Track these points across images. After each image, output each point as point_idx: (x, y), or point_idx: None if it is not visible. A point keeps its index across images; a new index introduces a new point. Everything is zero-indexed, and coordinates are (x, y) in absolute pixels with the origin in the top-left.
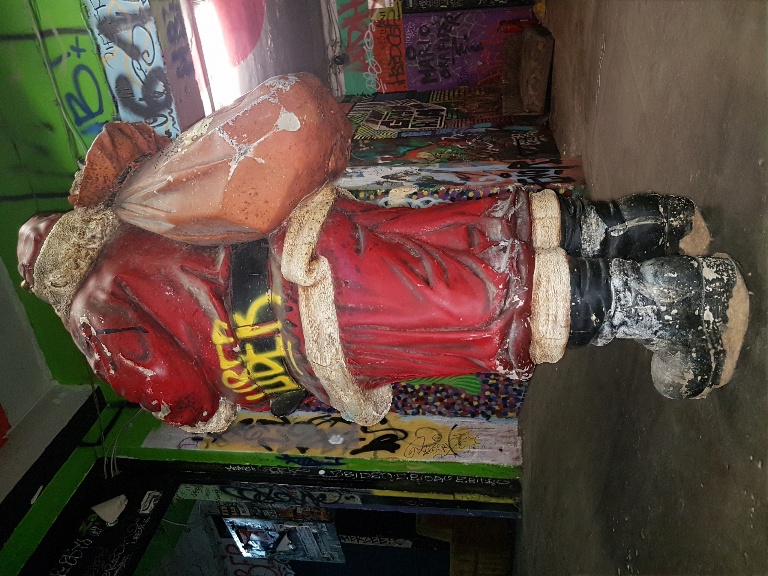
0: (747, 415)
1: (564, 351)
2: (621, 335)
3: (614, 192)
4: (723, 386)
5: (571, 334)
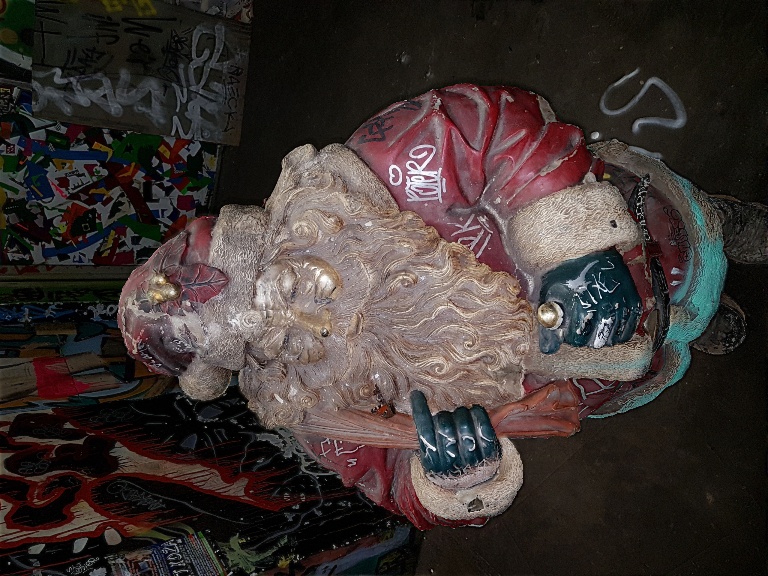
0: None
1: None
2: None
3: (645, 569)
4: None
5: None
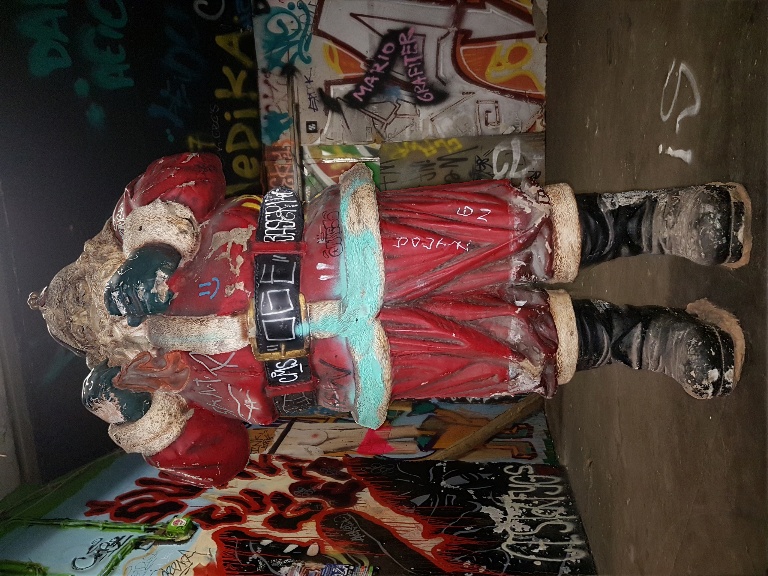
0: (763, 154)
1: (575, 200)
2: (623, 201)
3: None
4: (761, 213)
5: (575, 193)
